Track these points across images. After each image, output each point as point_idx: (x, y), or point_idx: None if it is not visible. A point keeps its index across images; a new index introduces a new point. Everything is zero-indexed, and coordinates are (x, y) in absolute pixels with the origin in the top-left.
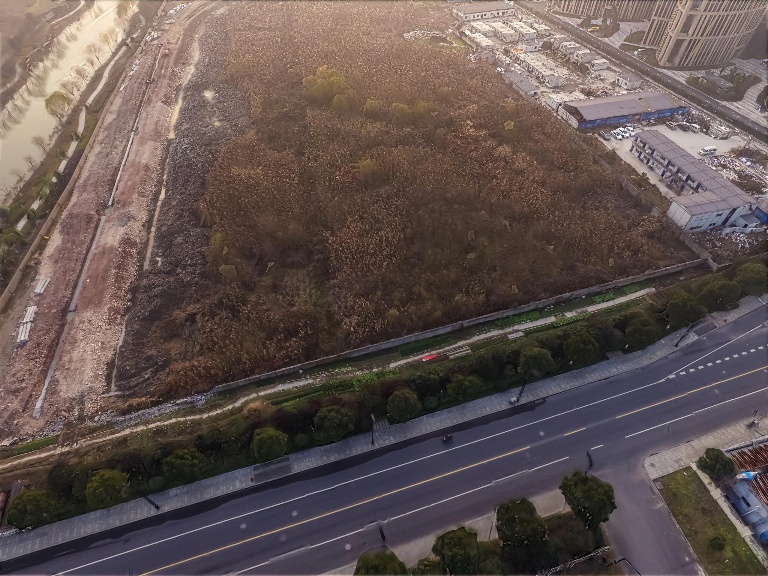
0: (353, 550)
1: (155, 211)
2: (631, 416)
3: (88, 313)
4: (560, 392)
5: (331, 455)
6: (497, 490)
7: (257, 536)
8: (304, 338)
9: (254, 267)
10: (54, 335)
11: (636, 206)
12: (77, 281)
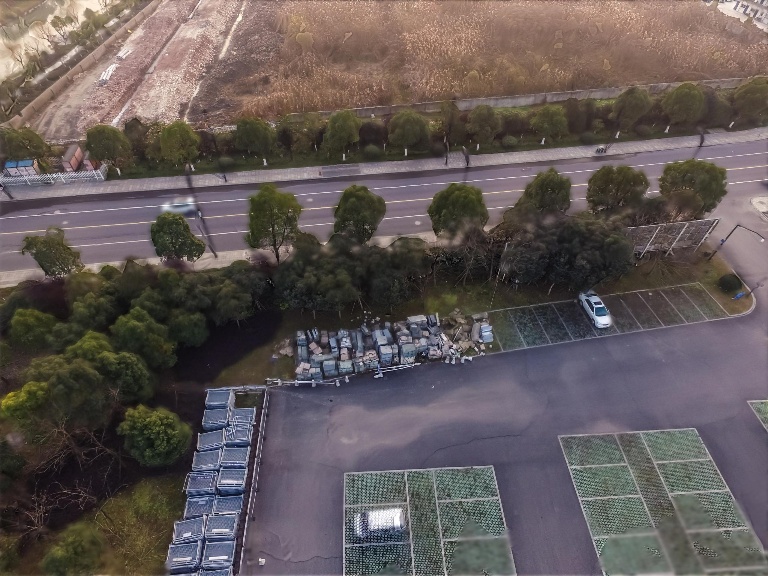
0: (423, 225)
1: (232, 26)
2: (736, 171)
3: (166, 72)
4: (653, 151)
5: (402, 167)
6: (581, 205)
7: (324, 207)
8: (378, 93)
9: (328, 57)
10: (133, 82)
11: (741, 42)
12: (156, 56)
